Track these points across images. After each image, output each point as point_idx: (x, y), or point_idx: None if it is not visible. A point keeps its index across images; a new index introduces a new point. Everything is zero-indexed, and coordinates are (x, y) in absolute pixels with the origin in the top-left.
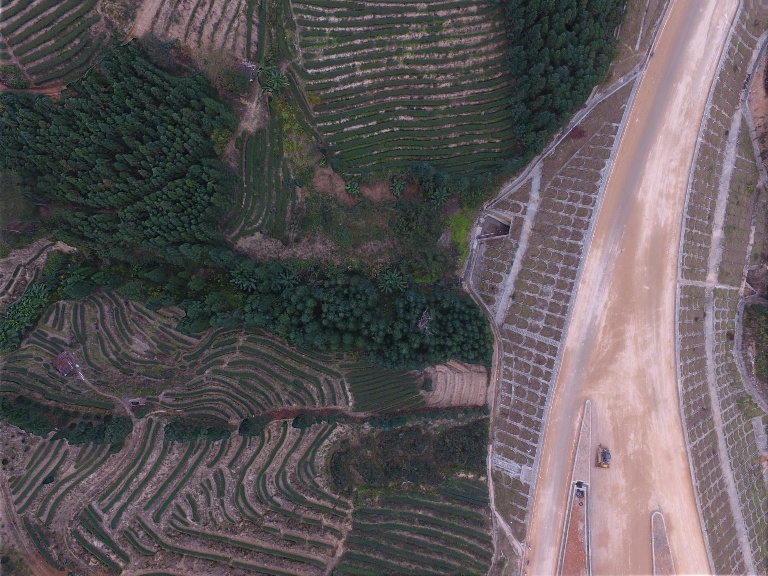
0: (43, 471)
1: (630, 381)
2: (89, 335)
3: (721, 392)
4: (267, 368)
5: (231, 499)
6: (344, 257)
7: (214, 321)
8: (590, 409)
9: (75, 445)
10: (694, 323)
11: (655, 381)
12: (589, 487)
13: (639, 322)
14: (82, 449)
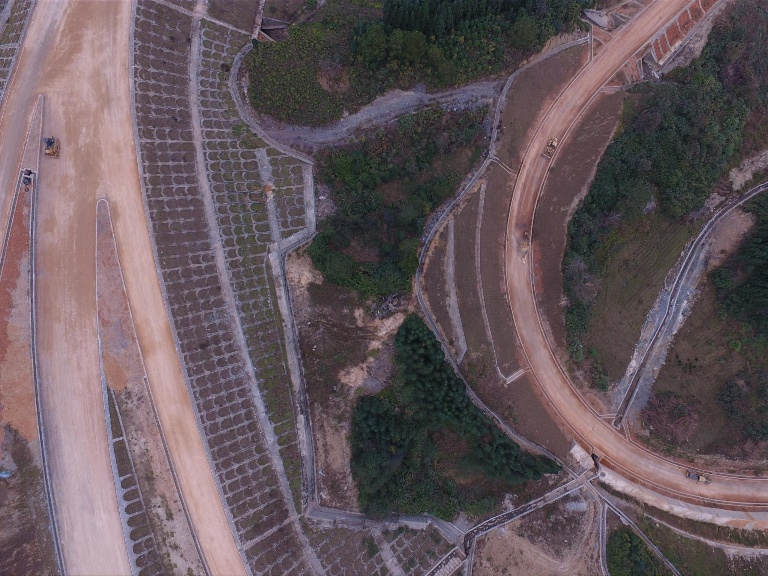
0: None
1: (85, 80)
2: None
3: (206, 112)
4: None
5: None
6: None
7: None
8: (42, 103)
9: None
10: (167, 41)
11: (109, 81)
12: (37, 175)
13: (97, 27)
14: None
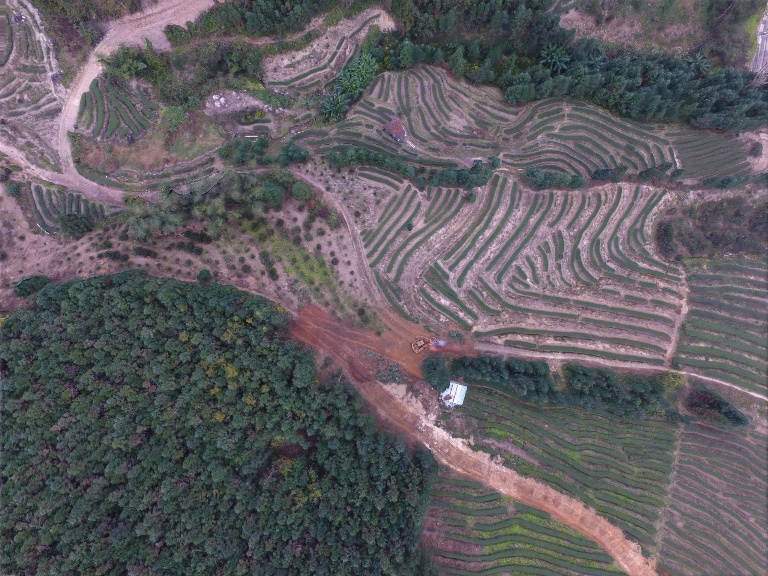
0: (395, 224)
1: None
2: (412, 107)
3: None
4: (599, 133)
5: (567, 263)
6: (646, 42)
7: (552, 82)
8: None
9: (425, 199)
10: None
11: None
12: None
13: None
14: (432, 202)
